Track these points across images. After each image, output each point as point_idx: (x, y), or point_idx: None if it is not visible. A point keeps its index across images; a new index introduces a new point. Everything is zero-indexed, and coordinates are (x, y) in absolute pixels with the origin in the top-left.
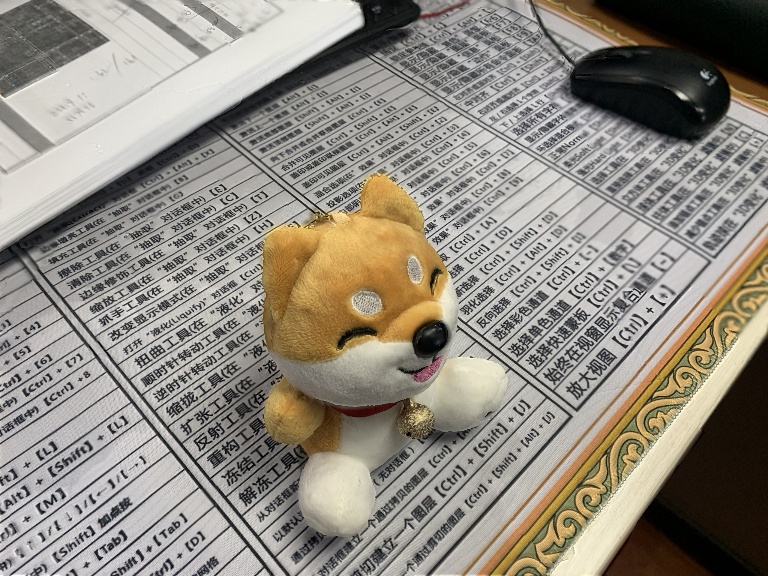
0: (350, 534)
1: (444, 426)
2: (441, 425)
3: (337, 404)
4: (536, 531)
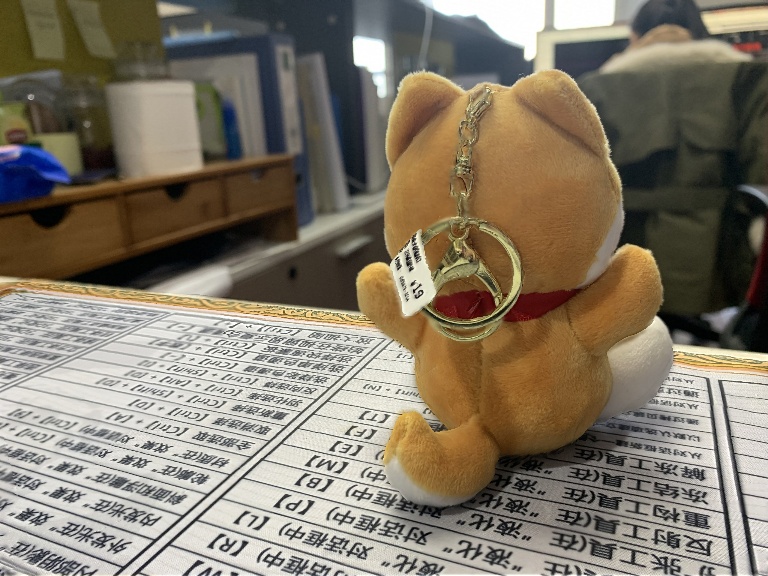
0: None
1: None
2: None
3: None
4: None
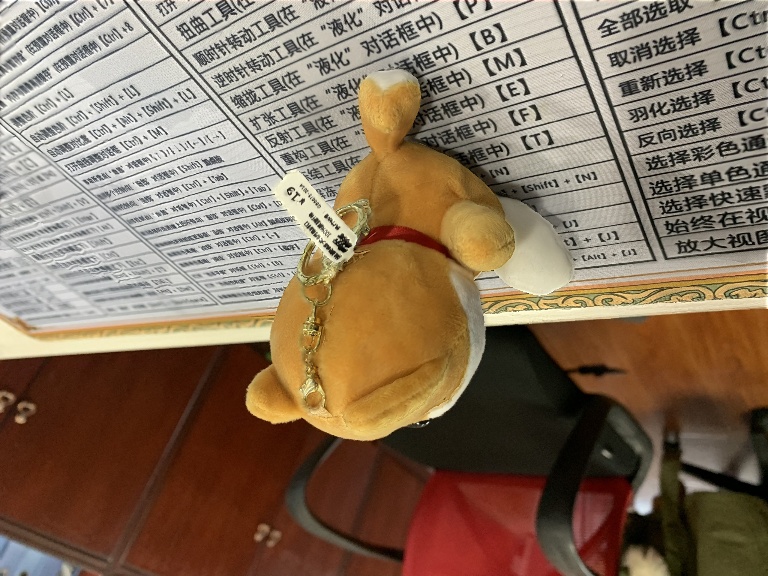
0: None
1: None
2: None
3: None
4: None
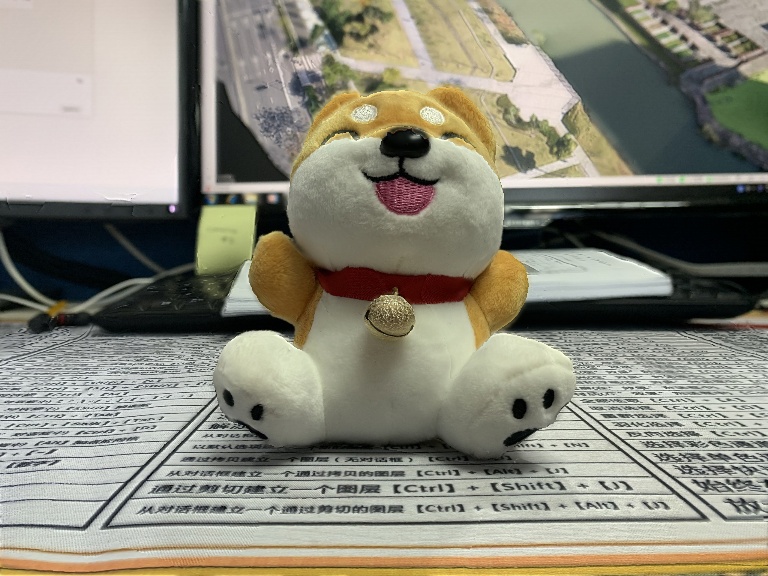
0: (232, 382)
1: (453, 409)
2: (450, 408)
3: (301, 216)
4: (494, 574)
